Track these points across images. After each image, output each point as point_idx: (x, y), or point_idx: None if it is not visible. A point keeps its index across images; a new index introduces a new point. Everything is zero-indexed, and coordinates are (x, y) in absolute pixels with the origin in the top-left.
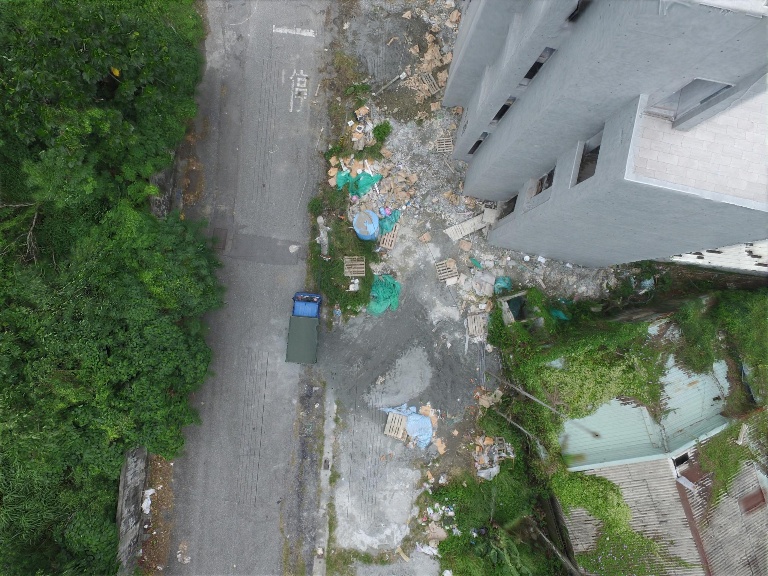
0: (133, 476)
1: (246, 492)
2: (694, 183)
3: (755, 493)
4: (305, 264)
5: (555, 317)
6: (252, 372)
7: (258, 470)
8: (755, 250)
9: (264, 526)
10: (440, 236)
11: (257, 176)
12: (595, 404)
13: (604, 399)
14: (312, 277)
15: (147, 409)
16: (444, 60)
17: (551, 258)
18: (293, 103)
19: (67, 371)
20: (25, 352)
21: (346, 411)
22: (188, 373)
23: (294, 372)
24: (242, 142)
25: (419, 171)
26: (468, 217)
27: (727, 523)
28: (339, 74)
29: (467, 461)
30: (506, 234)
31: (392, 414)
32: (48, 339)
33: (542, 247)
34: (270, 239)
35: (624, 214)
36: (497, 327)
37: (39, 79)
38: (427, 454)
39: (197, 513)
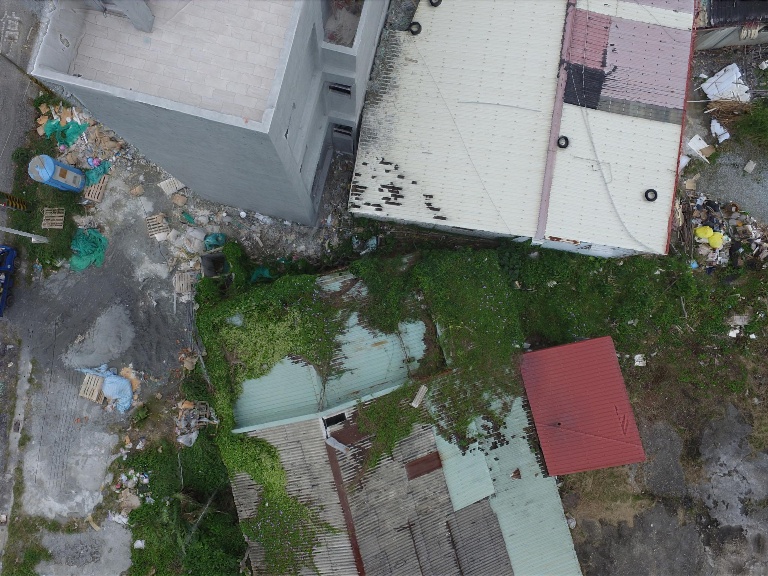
0: None
1: None
2: (157, 89)
3: (429, 459)
4: (5, 215)
5: (257, 275)
6: None
7: None
8: (434, 202)
9: None
10: (154, 190)
11: None
12: (268, 363)
13: (275, 357)
14: None
15: None
16: None
17: (268, 215)
18: (2, 46)
19: None
20: None
21: (42, 371)
22: None
23: None
24: None
25: None
26: None
27: (388, 489)
28: None
29: (169, 426)
30: None
31: (88, 375)
32: None
33: (231, 198)
34: None
35: (148, 134)
36: None
37: None
38: (127, 418)
39: None
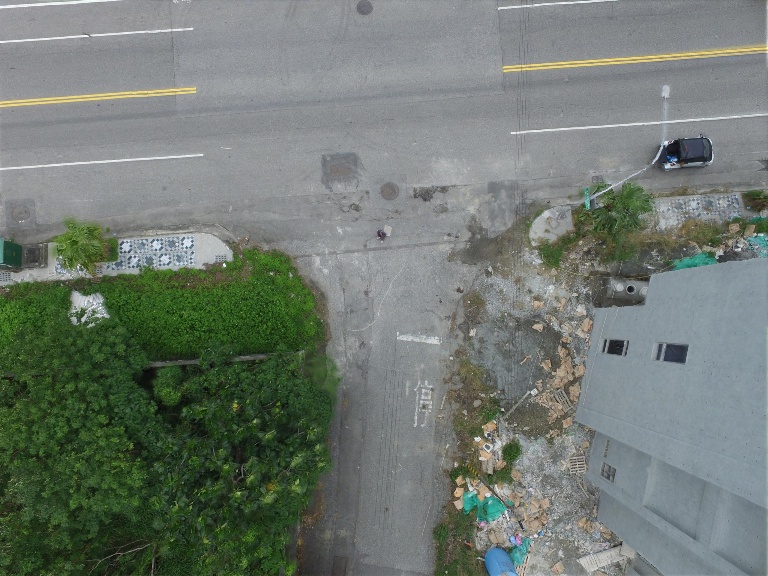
0: None
1: None
2: None
3: None
4: None
5: None
6: None
7: None
8: None
9: None
10: (573, 566)
11: (379, 499)
12: None
13: None
14: None
15: None
16: (576, 372)
17: None
18: (417, 417)
19: None
20: None
21: None
22: None
23: None
24: (364, 460)
25: (551, 494)
26: (604, 547)
27: None
28: (465, 384)
29: None
30: None
31: None
32: None
33: None
34: (393, 571)
35: None
36: None
37: (199, 526)
38: None
39: None
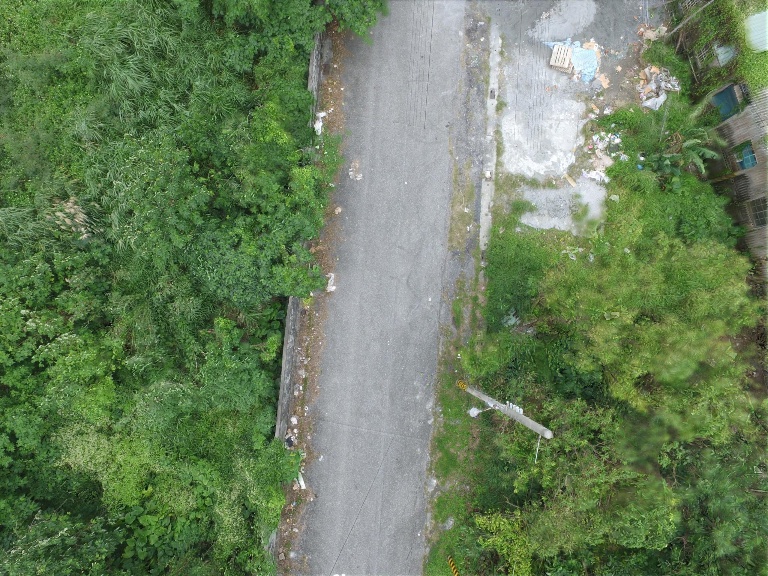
0: None
1: (416, 115)
2: None
3: None
4: None
5: None
6: (419, 4)
7: (427, 95)
8: None
9: (434, 147)
10: None
11: None
12: None
13: None
14: None
15: None
16: None
17: None
18: None
19: None
20: None
21: (511, 46)
22: None
23: (460, 6)
24: None
25: None
26: None
27: None
28: None
29: (631, 95)
30: None
31: (558, 46)
32: None
33: None
34: None
35: None
36: None
37: None
38: (591, 88)
39: (368, 134)
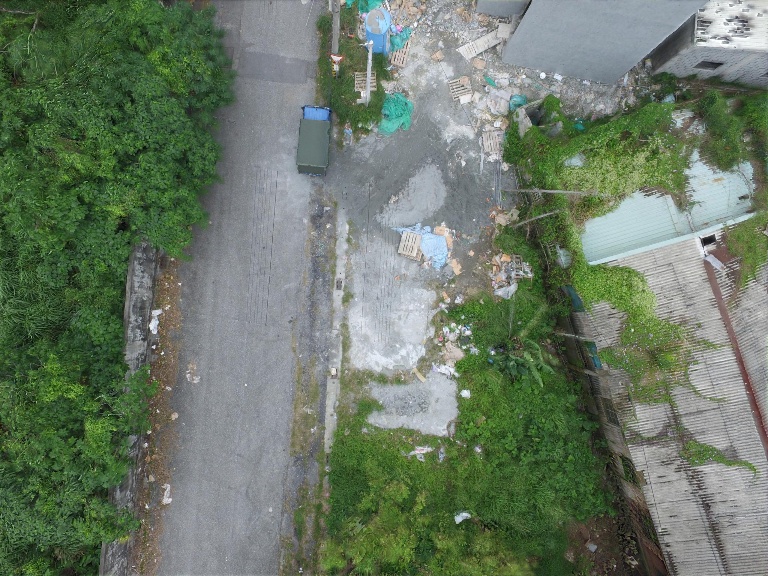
0: (140, 286)
1: (256, 311)
2: None
3: None
4: (314, 83)
5: None
6: (261, 191)
7: (269, 289)
8: None
9: (275, 345)
10: (453, 55)
11: None
12: (617, 198)
13: (627, 191)
14: (322, 95)
15: (154, 187)
16: None
17: (568, 75)
18: None
19: (71, 141)
20: (27, 126)
21: (358, 231)
22: (196, 163)
23: (304, 191)
24: None
25: None
26: (482, 34)
27: (756, 309)
28: None
29: (484, 281)
30: (523, 25)
31: (406, 233)
32: (51, 106)
33: (560, 46)
34: (278, 56)
35: None
36: (513, 143)
37: None
38: (442, 275)
39: (206, 332)
